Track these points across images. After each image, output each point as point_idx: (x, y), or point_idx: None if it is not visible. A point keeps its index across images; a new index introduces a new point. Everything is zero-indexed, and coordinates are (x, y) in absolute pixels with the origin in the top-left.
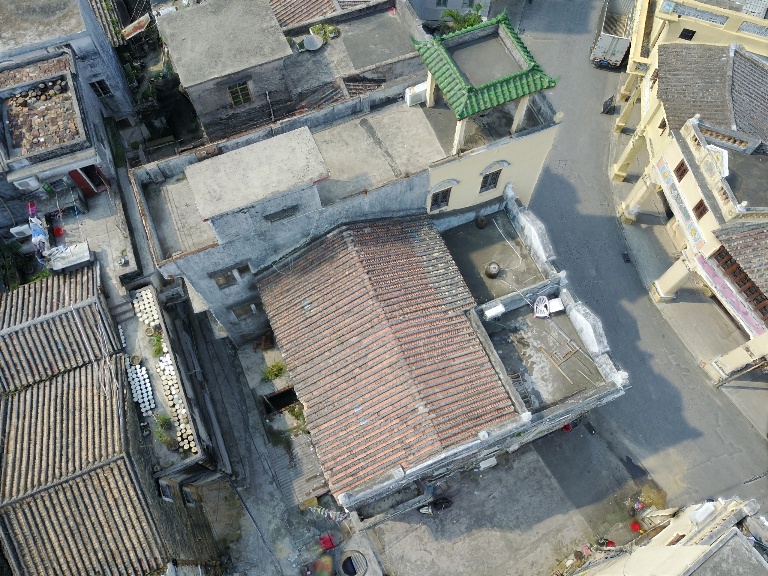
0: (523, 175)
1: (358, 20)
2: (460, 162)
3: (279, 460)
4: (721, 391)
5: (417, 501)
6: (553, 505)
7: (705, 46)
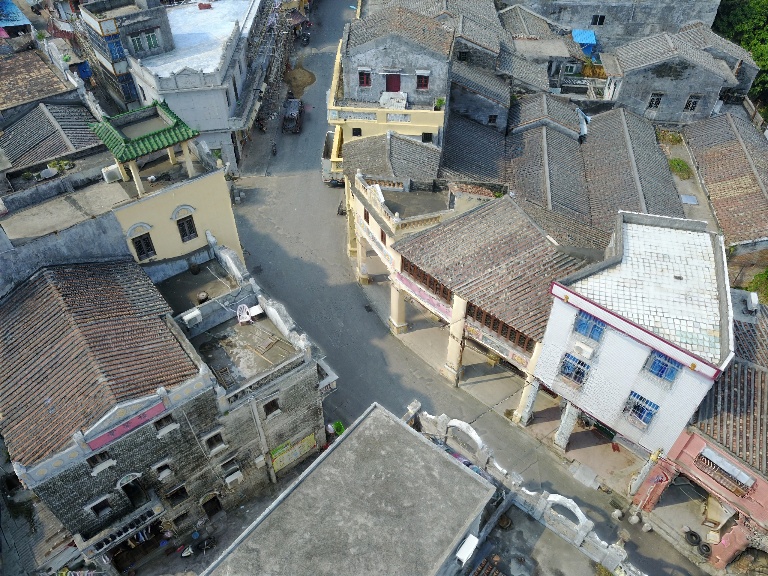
0: (218, 223)
1: (92, 156)
2: (140, 203)
3: (19, 531)
4: (461, 389)
5: (144, 509)
6: None
7: (372, 138)
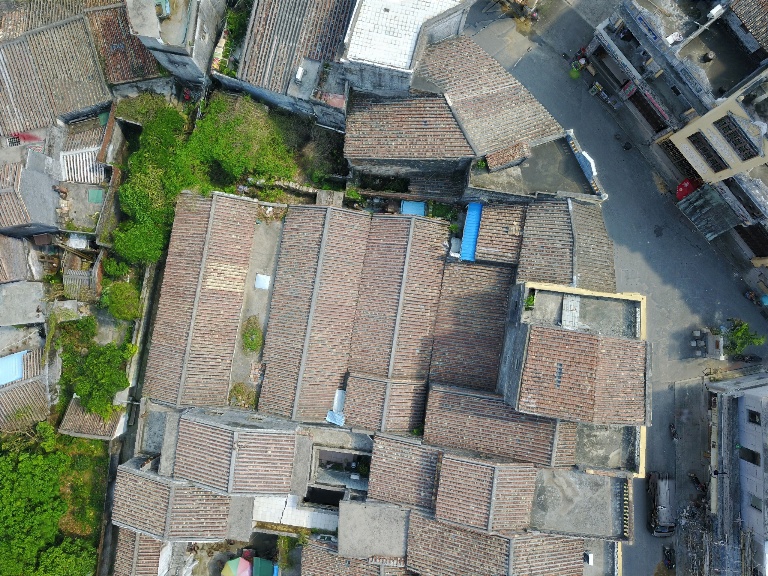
0: None
1: None
2: None
3: None
4: None
5: None
6: (583, 3)
7: None
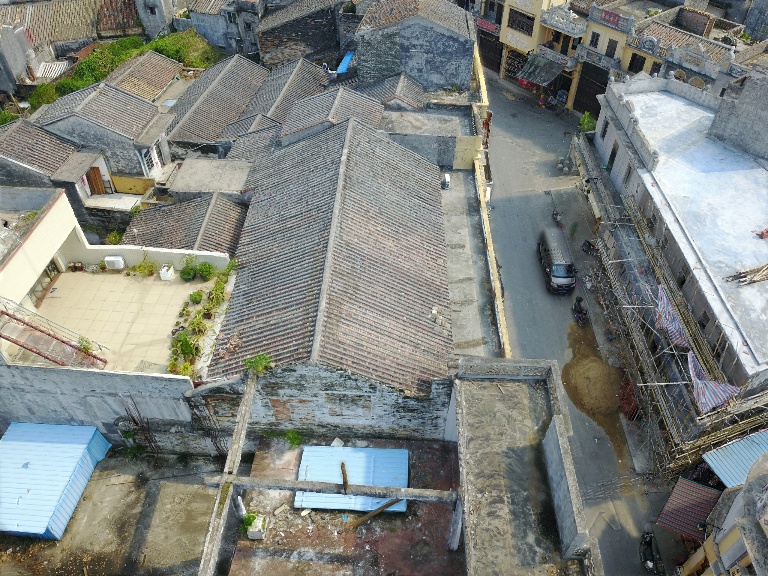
0: None
1: None
2: None
3: None
4: None
5: None
6: None
7: None
